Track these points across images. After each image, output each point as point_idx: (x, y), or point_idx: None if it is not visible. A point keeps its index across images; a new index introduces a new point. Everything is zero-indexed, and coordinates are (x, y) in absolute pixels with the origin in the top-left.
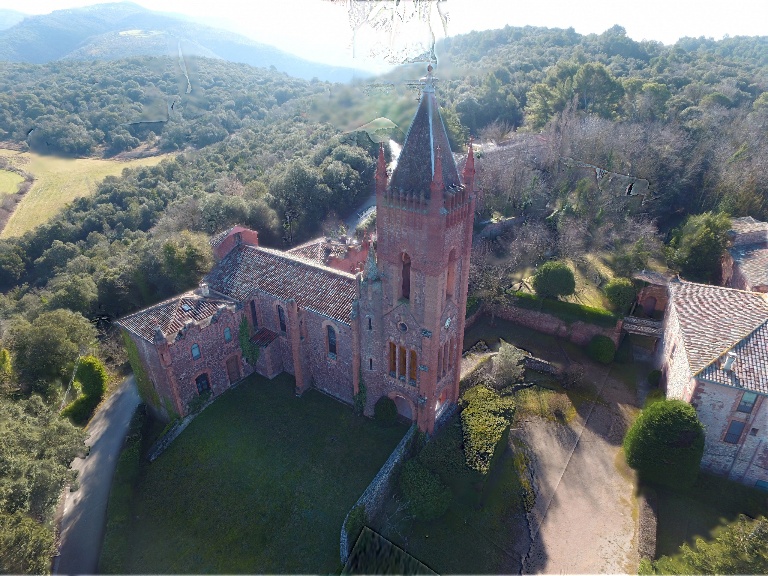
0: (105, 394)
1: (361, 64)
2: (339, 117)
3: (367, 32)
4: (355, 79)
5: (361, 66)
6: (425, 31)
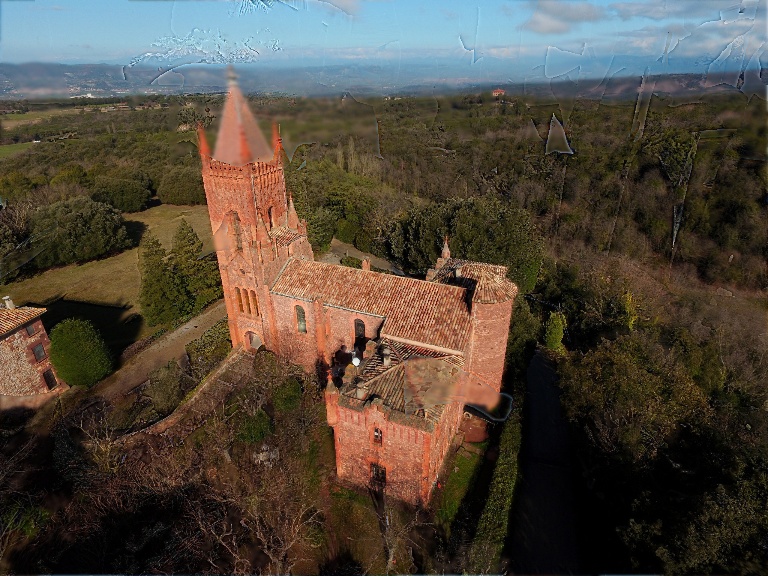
0: (545, 347)
1: (295, 62)
2: (328, 130)
3: (280, 14)
4: (305, 83)
5: (295, 65)
6: (183, 8)
